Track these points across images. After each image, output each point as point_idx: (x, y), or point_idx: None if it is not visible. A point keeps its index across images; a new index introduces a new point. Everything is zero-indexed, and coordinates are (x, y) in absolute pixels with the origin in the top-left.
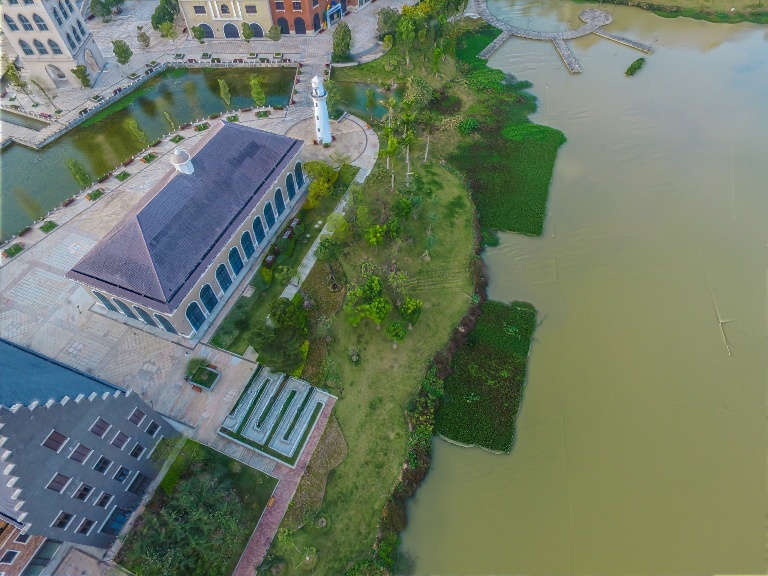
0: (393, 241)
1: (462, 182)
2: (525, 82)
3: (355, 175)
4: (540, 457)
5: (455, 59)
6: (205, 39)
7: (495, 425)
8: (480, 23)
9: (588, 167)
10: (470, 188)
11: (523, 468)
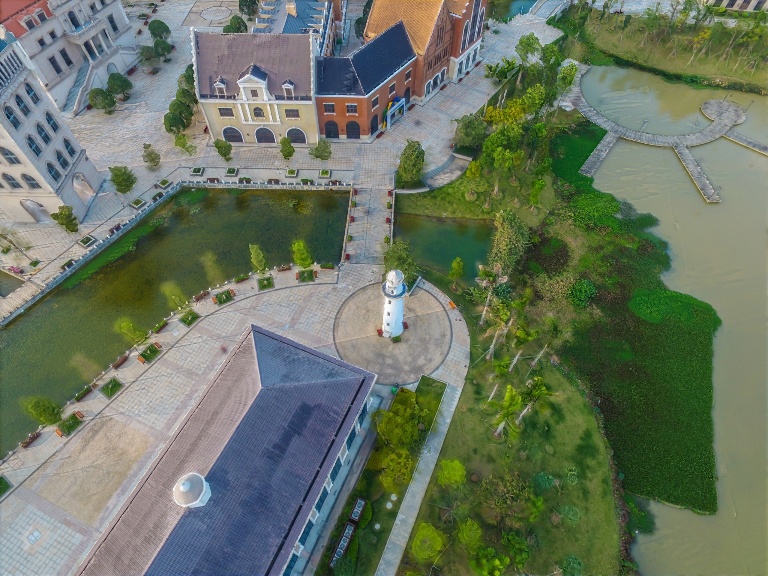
0: None
1: (587, 400)
2: (648, 217)
3: (440, 399)
4: None
5: (551, 176)
6: (231, 144)
7: None
8: (576, 118)
9: (761, 375)
10: (600, 413)
11: None
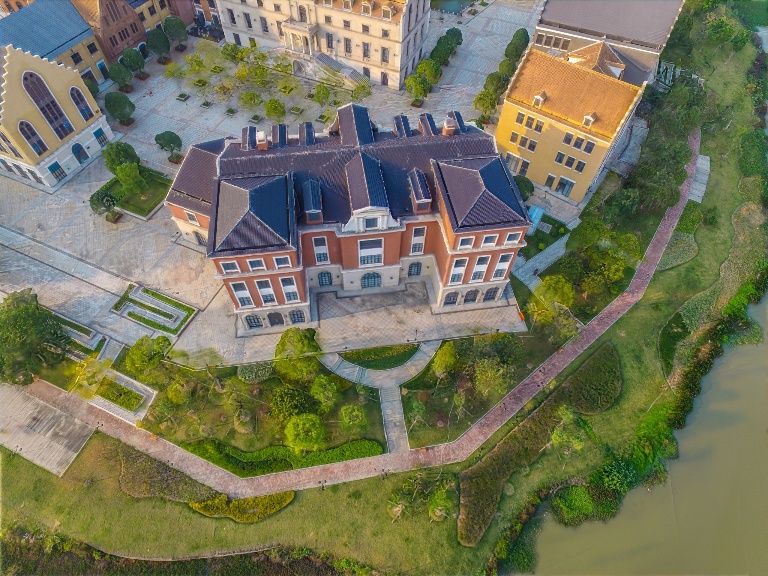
0: (718, 8)
1: None
2: None
3: None
4: None
5: None
6: None
7: None
8: None
9: None
10: None
11: None
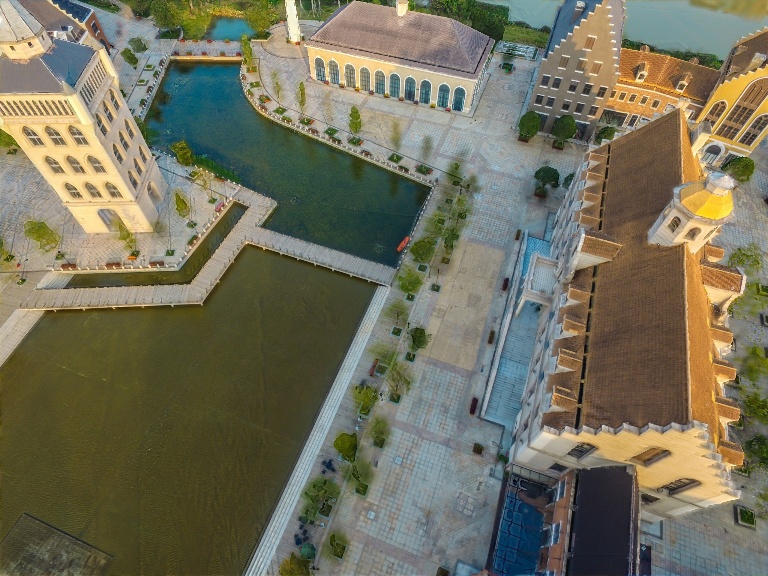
0: None
1: None
2: None
3: None
4: (508, 1)
5: (175, 0)
6: None
7: (498, 8)
8: None
9: None
10: None
11: (514, 5)
